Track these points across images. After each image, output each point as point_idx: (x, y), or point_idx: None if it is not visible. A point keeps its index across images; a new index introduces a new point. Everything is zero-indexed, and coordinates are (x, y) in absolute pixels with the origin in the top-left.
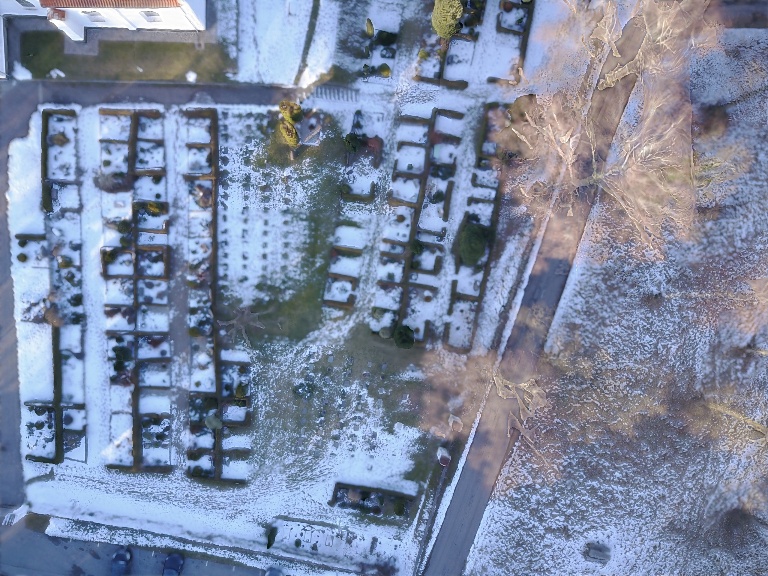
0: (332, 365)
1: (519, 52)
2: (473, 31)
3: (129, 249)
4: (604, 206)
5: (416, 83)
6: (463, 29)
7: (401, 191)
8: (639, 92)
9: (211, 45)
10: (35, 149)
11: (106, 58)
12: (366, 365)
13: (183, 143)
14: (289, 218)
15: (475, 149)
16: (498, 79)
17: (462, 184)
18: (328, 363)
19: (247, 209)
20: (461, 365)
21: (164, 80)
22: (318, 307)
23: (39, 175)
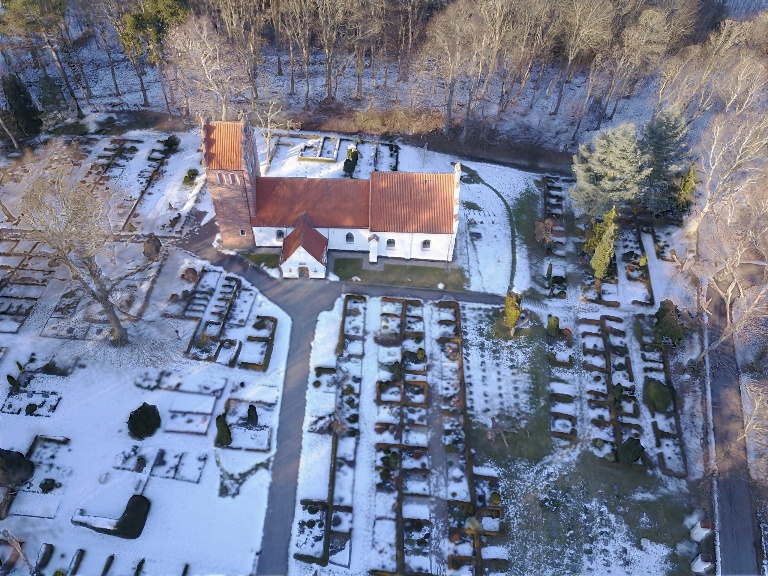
0: (570, 484)
1: (647, 290)
2: (614, 279)
3: (399, 382)
4: (748, 375)
5: (585, 302)
6: (607, 278)
7: (593, 361)
8: (737, 312)
9: (455, 269)
10: (336, 317)
11: (389, 272)
12: (599, 485)
13: (436, 321)
14: (515, 371)
15: (637, 340)
16: (640, 301)
17: (636, 360)
18: (566, 482)
19: (484, 363)
20: (683, 488)
21: (423, 287)
22: (548, 436)
23: (337, 332)
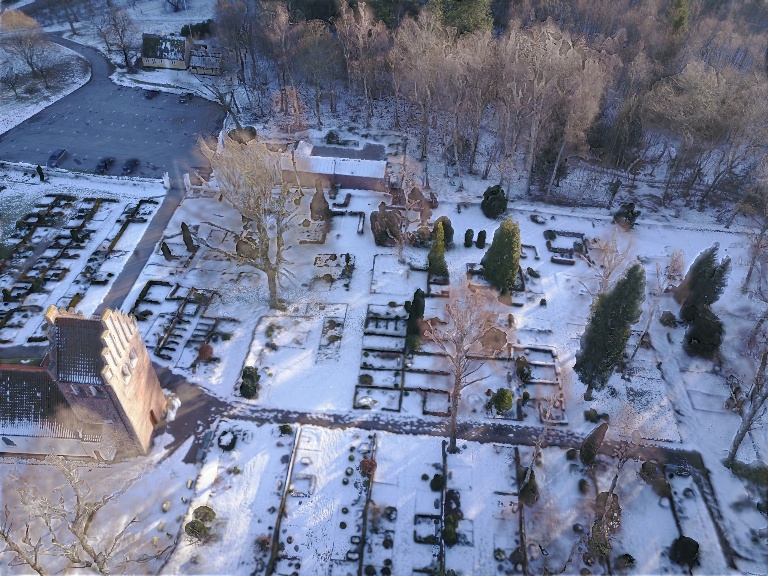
0: None
1: None
2: None
3: None
4: None
5: None
6: None
7: None
8: None
9: None
10: None
11: None
12: None
13: None
14: None
15: None
16: None
17: None
18: None
19: None
20: None
21: None
22: None
23: None
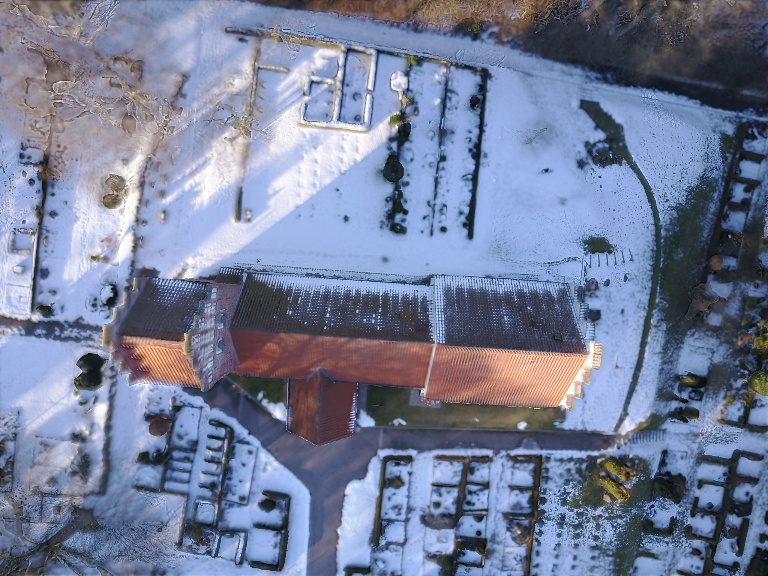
0: None
1: None
2: None
3: None
4: None
5: (721, 425)
6: None
7: (699, 527)
8: None
9: None
10: (371, 490)
11: (448, 411)
12: None
13: (506, 484)
14: (596, 554)
15: None
16: None
17: (756, 521)
18: None
19: (559, 546)
20: None
21: (496, 428)
22: None
23: (372, 514)
